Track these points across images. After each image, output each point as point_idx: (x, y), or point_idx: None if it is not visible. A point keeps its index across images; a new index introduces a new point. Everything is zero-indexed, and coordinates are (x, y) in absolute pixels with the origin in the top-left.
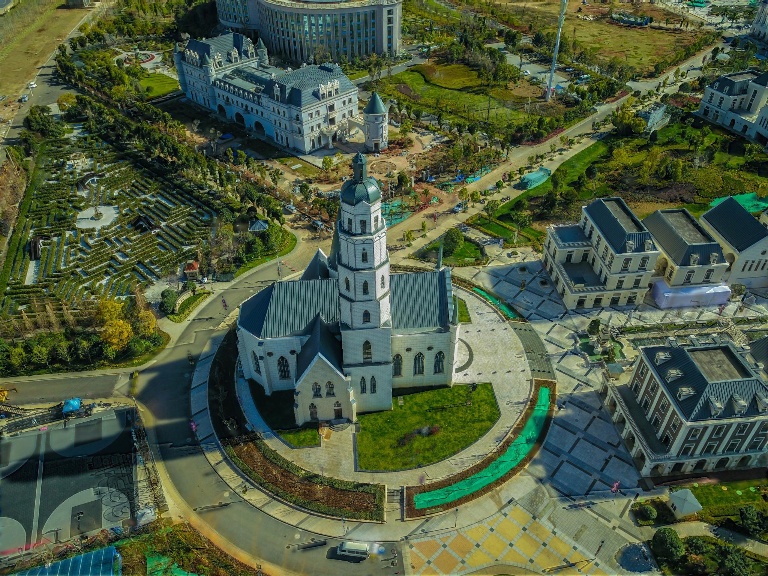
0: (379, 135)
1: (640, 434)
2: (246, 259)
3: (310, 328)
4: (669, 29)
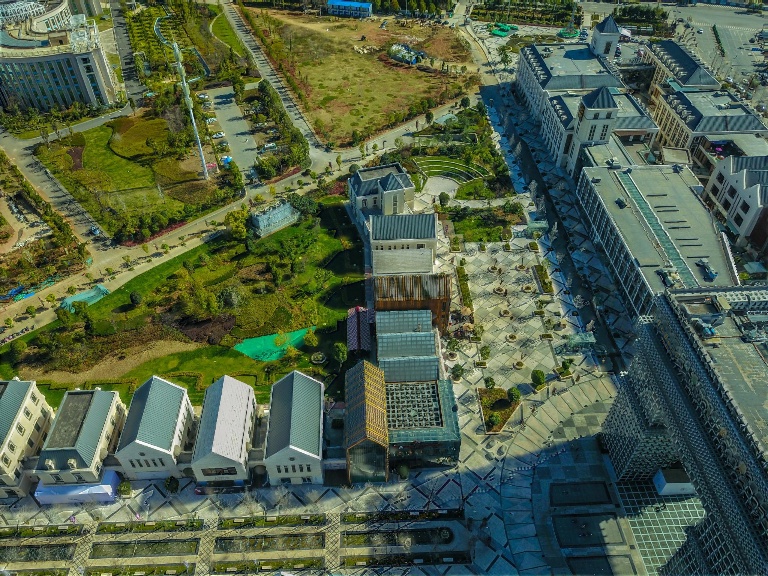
0: None
1: None
2: None
3: None
4: (433, 71)
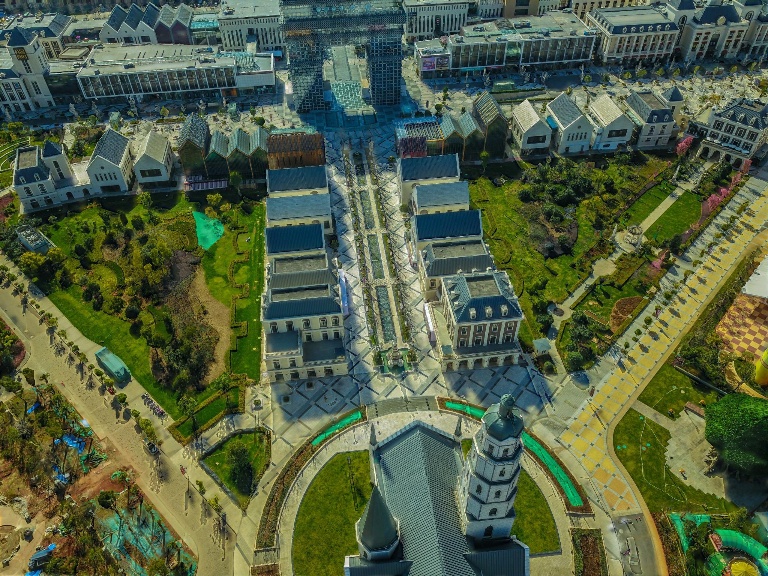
0: None
1: (503, 351)
2: None
3: (476, 569)
4: None
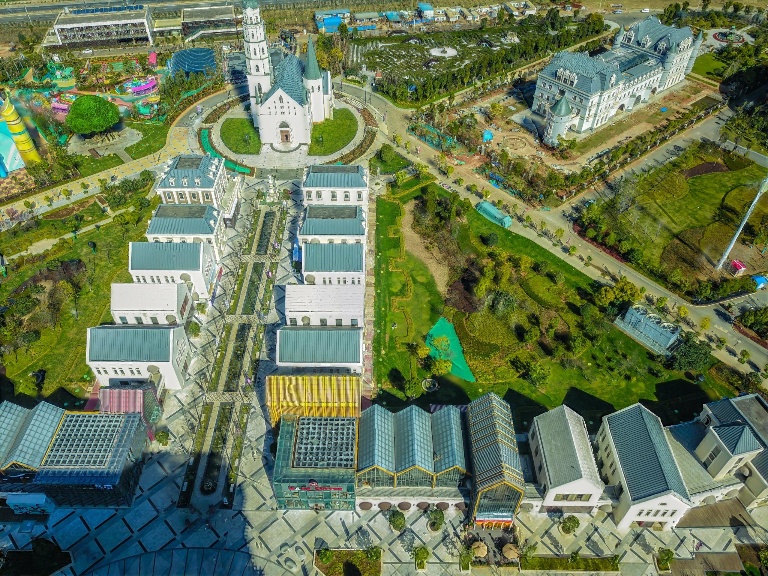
0: None
1: None
2: None
3: None
4: None
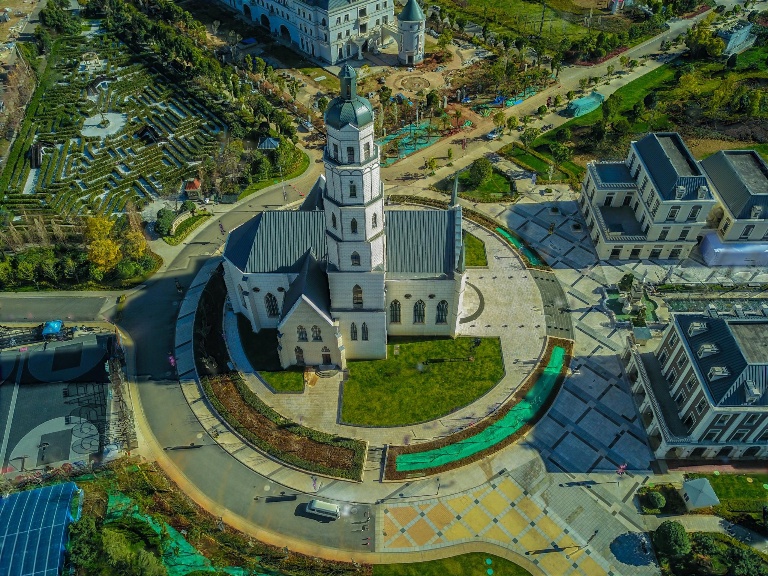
0: (414, 46)
1: (659, 412)
2: (252, 180)
3: (299, 265)
4: None
